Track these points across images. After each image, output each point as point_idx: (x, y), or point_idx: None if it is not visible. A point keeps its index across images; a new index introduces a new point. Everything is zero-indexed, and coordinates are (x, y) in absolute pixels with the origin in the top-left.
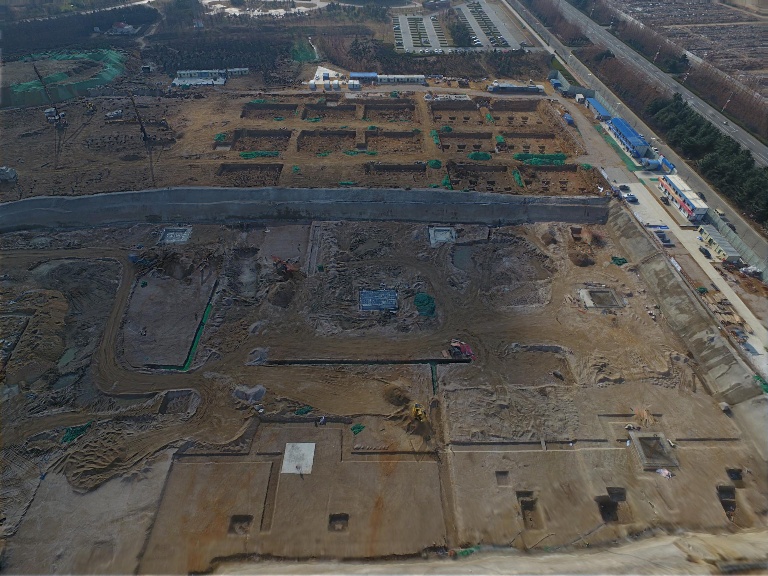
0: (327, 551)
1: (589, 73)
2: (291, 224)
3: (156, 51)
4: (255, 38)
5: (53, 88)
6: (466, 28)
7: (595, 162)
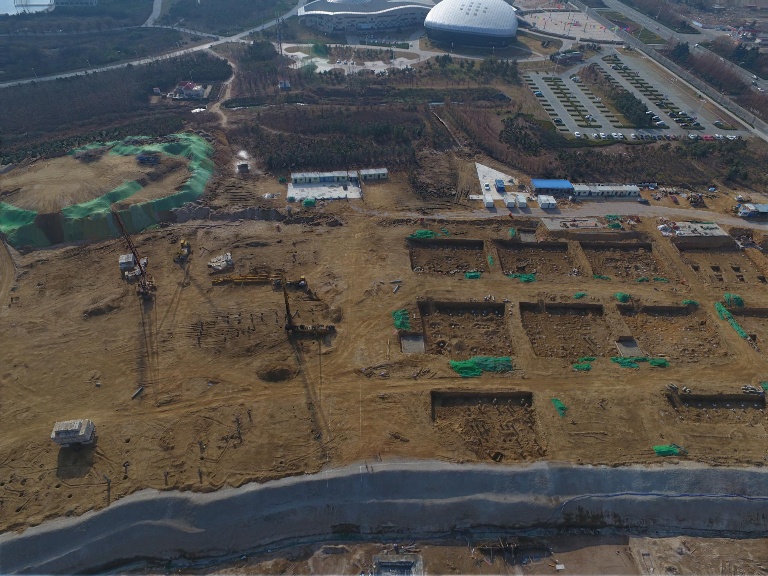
0: None
1: None
2: (592, 544)
3: (246, 132)
4: (371, 111)
5: (124, 211)
6: (638, 100)
7: None
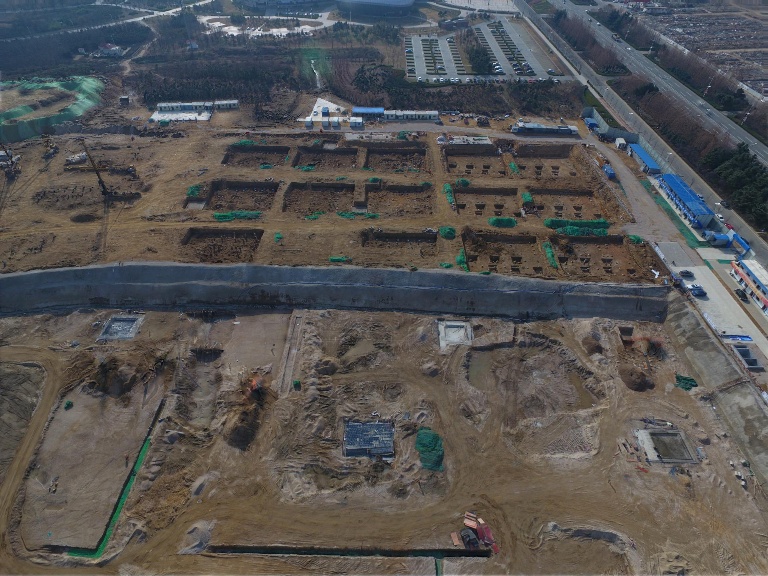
0: None
1: (629, 110)
2: (267, 313)
3: (140, 78)
4: (251, 63)
5: (12, 125)
6: (486, 53)
7: (646, 233)
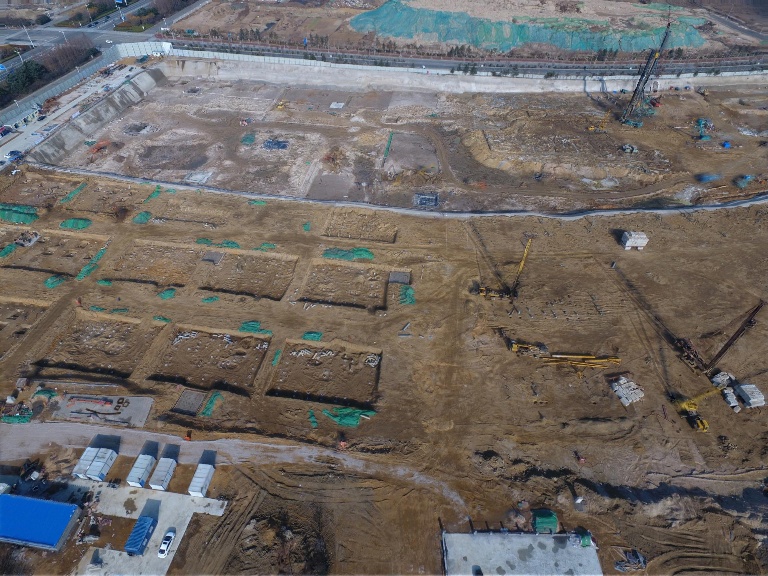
0: (330, 91)
1: None
2: None
3: None
4: None
5: None
6: None
7: None
